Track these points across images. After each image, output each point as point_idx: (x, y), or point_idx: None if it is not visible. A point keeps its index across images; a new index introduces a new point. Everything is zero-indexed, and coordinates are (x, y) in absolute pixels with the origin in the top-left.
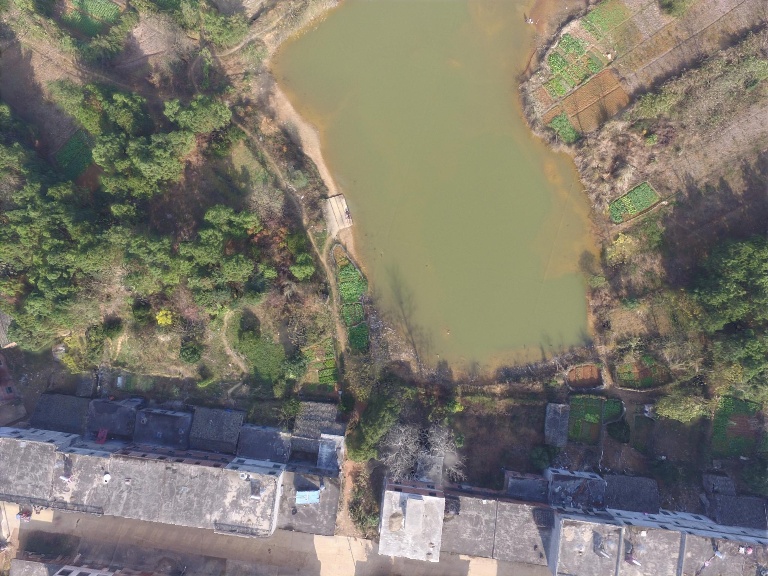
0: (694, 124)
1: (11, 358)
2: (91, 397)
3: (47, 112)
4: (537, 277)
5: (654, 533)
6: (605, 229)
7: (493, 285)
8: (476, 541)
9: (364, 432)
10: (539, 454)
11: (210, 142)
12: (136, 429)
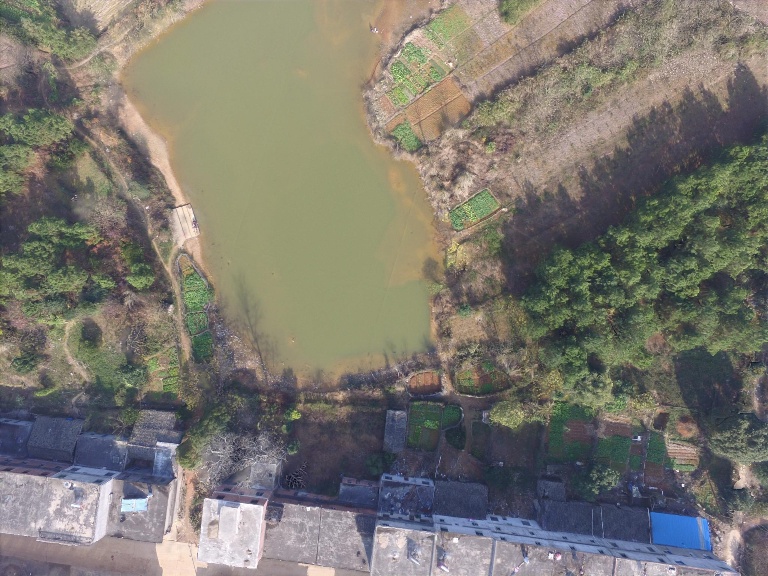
0: (533, 131)
1: None
2: None
3: None
4: (381, 284)
5: (466, 539)
6: (447, 236)
7: (338, 293)
8: (300, 548)
9: (191, 440)
10: (373, 461)
11: (51, 154)
12: None
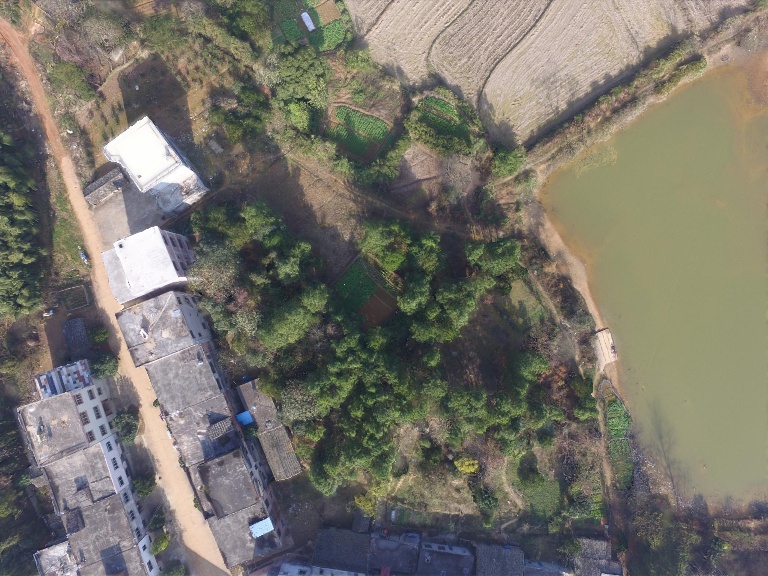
0: None
1: (278, 488)
2: (368, 532)
3: (321, 237)
4: None
5: None
6: None
7: (746, 421)
8: None
9: None
10: None
11: (497, 280)
12: (420, 568)
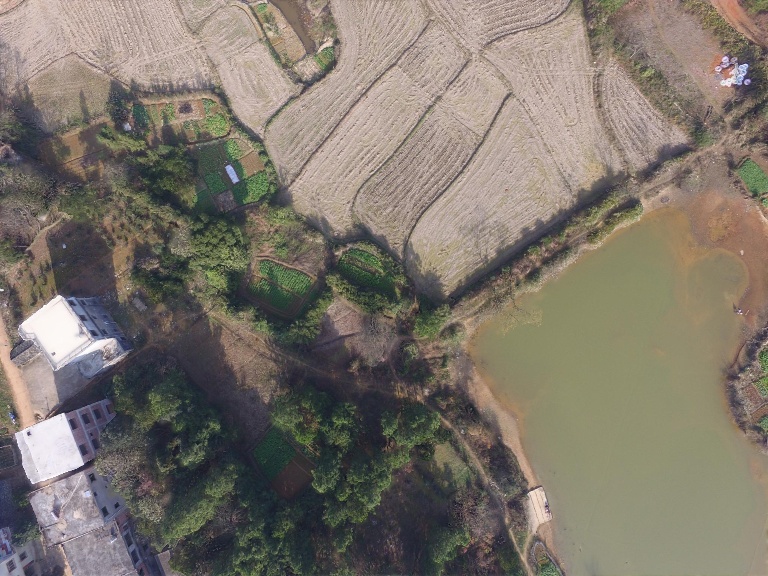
0: None
1: None
2: None
3: (241, 399)
4: None
5: None
6: None
7: None
8: None
9: None
10: None
11: (418, 446)
12: None
